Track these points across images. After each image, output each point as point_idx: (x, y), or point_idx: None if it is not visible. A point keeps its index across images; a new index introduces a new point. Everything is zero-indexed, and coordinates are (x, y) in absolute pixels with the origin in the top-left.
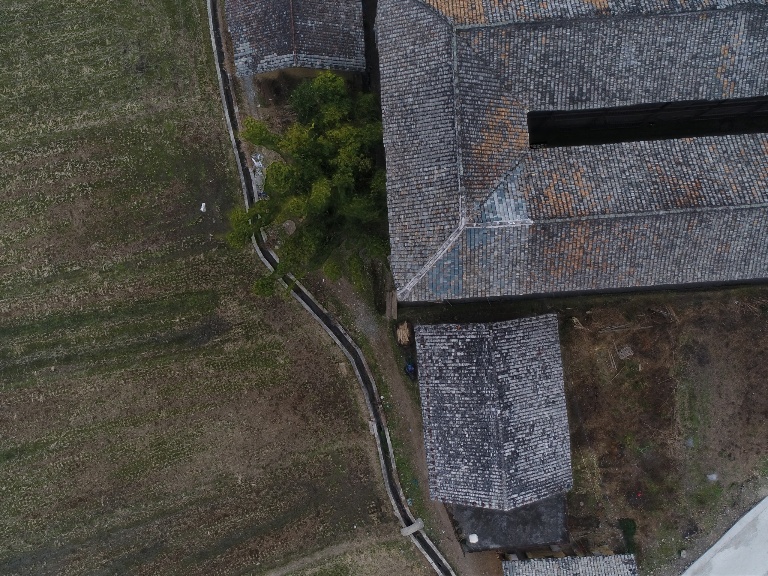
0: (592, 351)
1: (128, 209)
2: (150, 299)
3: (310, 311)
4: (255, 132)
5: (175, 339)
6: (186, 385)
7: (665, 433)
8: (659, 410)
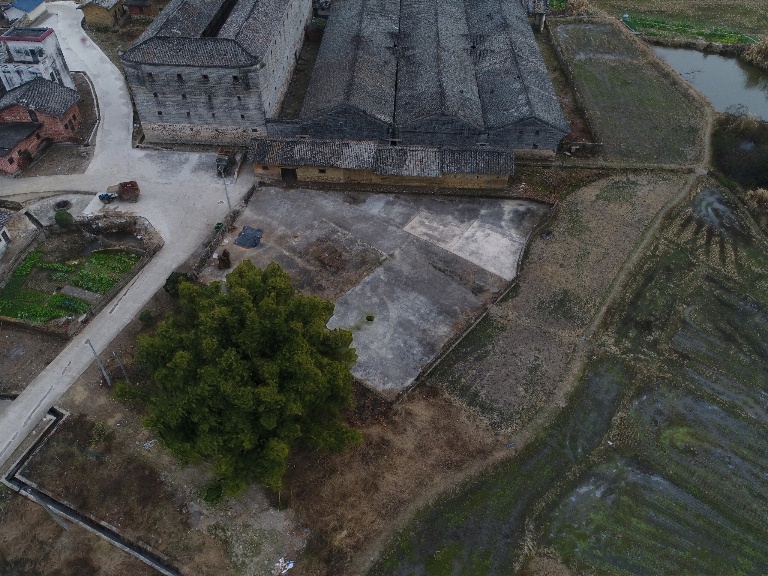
0: None
1: None
2: None
3: None
4: None
5: None
6: None
7: None
8: None
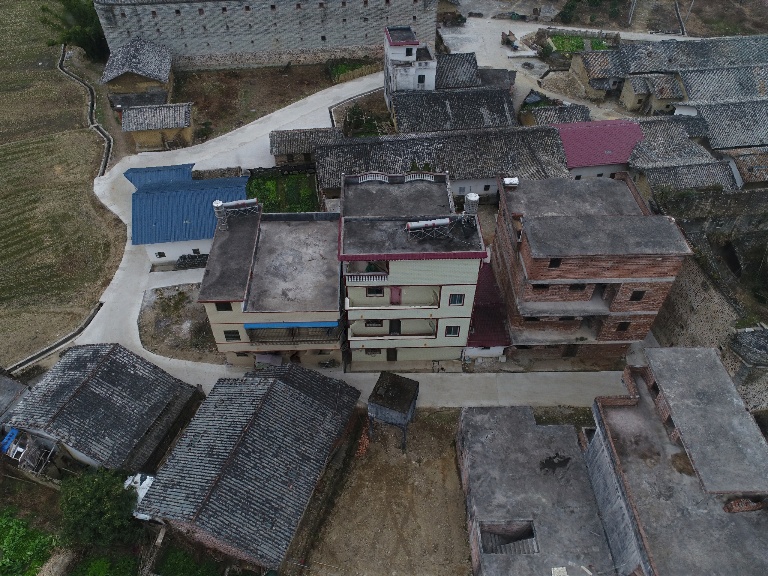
0: (202, 84)
1: (6, 65)
2: (1, 82)
3: (74, 79)
4: None
5: (6, 90)
6: (3, 99)
7: (231, 100)
8: (229, 94)
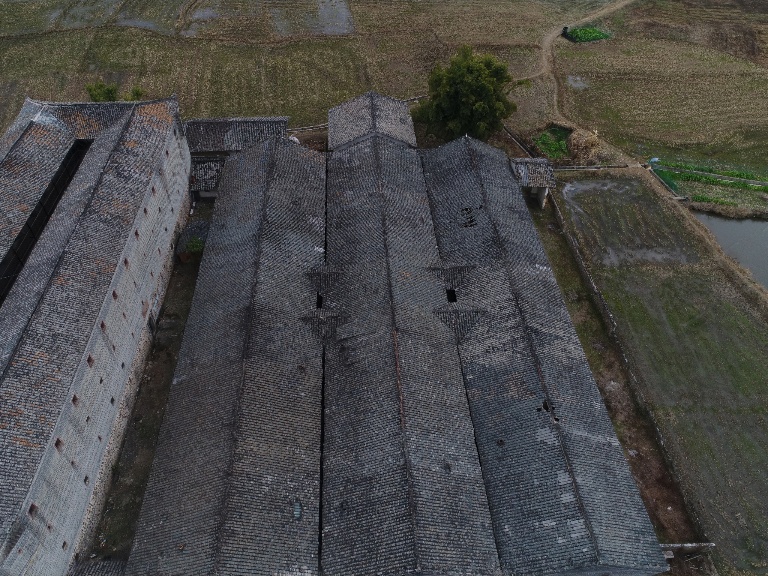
0: None
1: None
2: None
3: None
4: (136, 88)
5: None
6: None
7: None
8: None
